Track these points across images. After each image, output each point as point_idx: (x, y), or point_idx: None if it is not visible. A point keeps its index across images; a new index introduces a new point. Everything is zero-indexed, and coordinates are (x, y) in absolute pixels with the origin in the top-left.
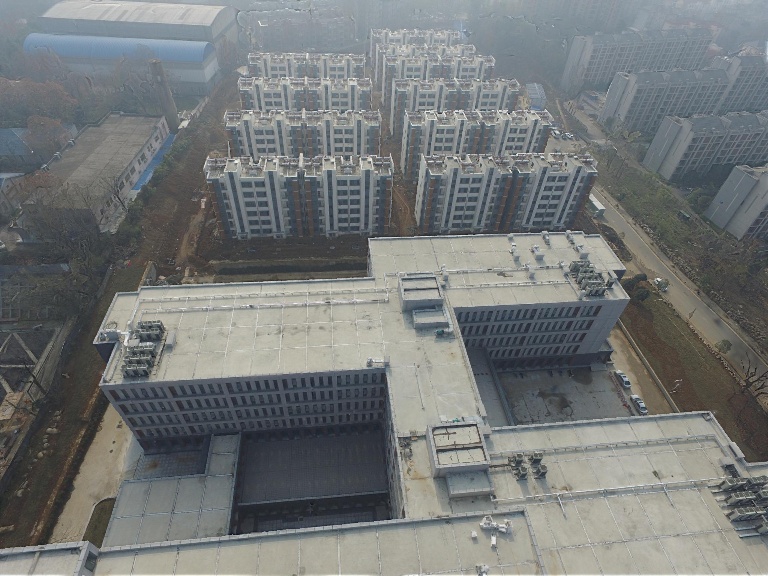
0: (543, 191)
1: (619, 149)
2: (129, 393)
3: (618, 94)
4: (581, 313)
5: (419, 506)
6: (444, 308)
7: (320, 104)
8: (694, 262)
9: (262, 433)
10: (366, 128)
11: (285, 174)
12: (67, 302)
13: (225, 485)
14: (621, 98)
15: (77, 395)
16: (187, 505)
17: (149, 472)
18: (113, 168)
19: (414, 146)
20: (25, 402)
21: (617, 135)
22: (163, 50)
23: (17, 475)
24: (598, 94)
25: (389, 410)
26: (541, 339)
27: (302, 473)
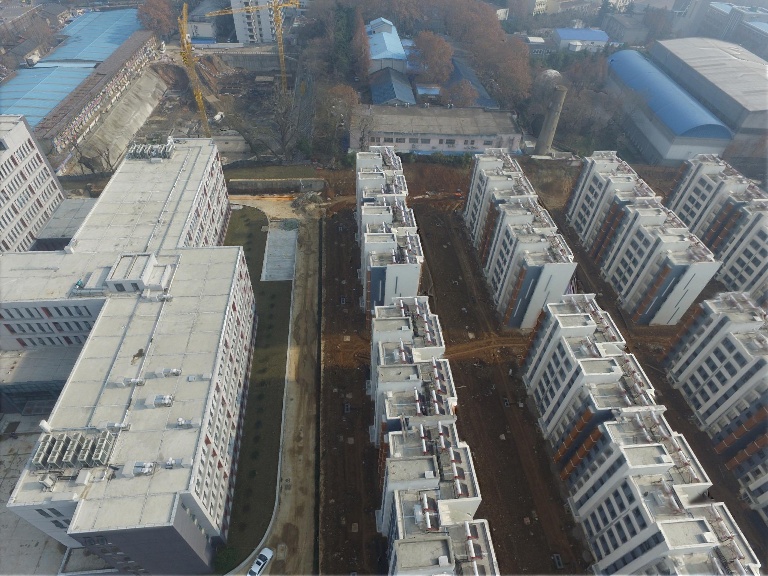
0: None
1: None
2: None
3: None
4: None
5: None
6: (105, 289)
7: None
8: None
9: None
10: None
11: (372, 192)
12: None
13: None
14: None
15: None
16: None
17: None
18: (415, 128)
19: (538, 333)
20: None
21: None
22: (670, 107)
23: None
24: None
25: None
26: None
27: None
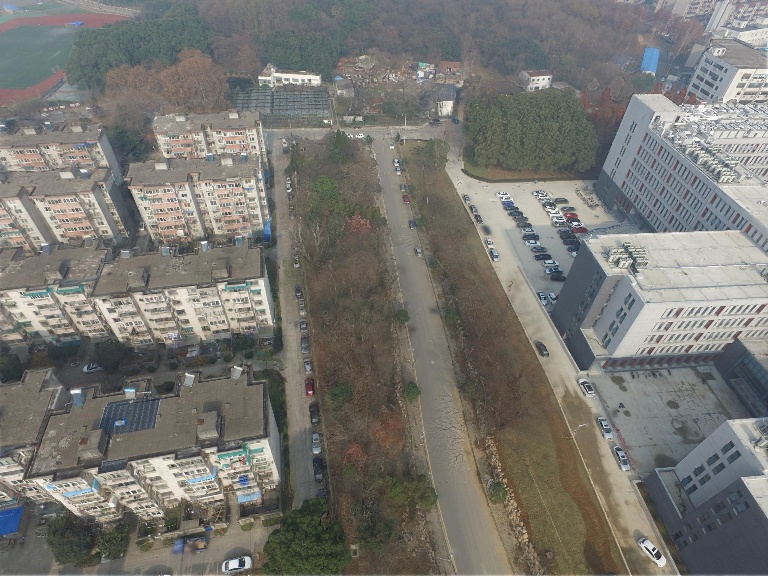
0: None
1: None
2: None
3: None
4: None
5: None
6: None
7: None
8: None
9: None
10: None
11: None
12: None
13: None
14: None
15: None
16: None
17: None
18: None
19: None
20: None
21: None
22: None
23: None
24: None
25: None
26: None
27: None
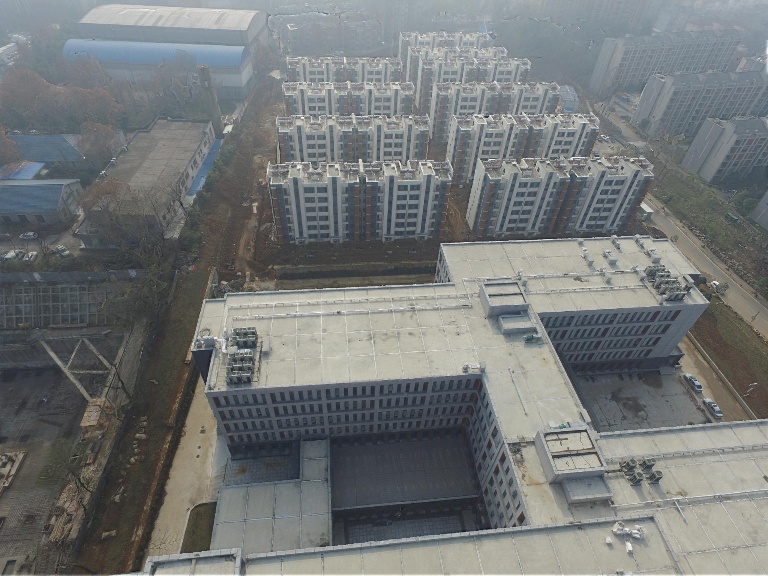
0: (599, 195)
1: (655, 151)
2: (230, 399)
3: (653, 96)
4: (659, 317)
5: (540, 512)
6: (529, 313)
7: (363, 108)
8: (748, 265)
9: (348, 438)
10: (416, 132)
11: (346, 179)
12: (146, 308)
13: (321, 490)
14: (656, 100)
15: (160, 401)
16: (287, 510)
17: (239, 477)
18: (170, 174)
19: (462, 150)
20: (106, 408)
21: (656, 137)
22: (201, 55)
23: (111, 481)
24: (630, 96)
25: (486, 415)
26: (615, 343)
27: (389, 478)
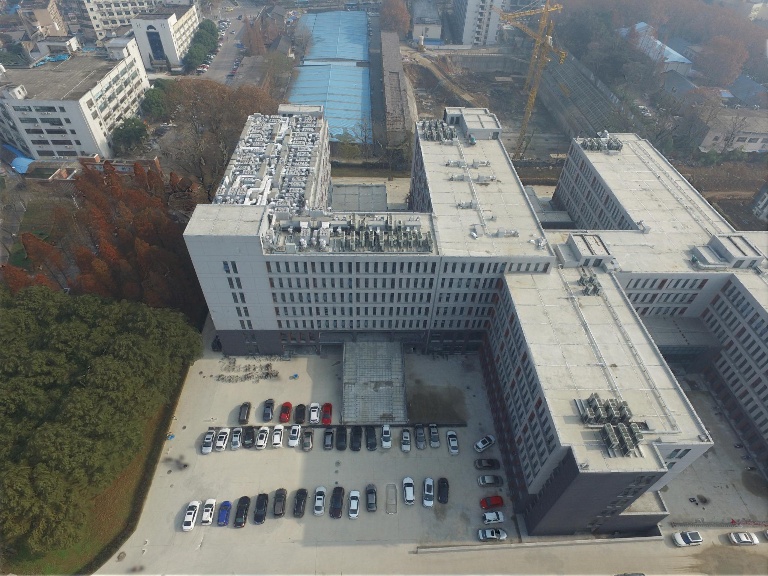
0: None
1: None
2: None
3: None
4: None
5: None
6: (727, 265)
7: None
8: None
9: None
10: None
11: None
12: None
13: (540, 219)
14: None
15: None
16: None
17: None
18: (767, 129)
19: None
20: None
21: None
22: None
23: None
24: None
25: None
26: (767, 397)
27: None
